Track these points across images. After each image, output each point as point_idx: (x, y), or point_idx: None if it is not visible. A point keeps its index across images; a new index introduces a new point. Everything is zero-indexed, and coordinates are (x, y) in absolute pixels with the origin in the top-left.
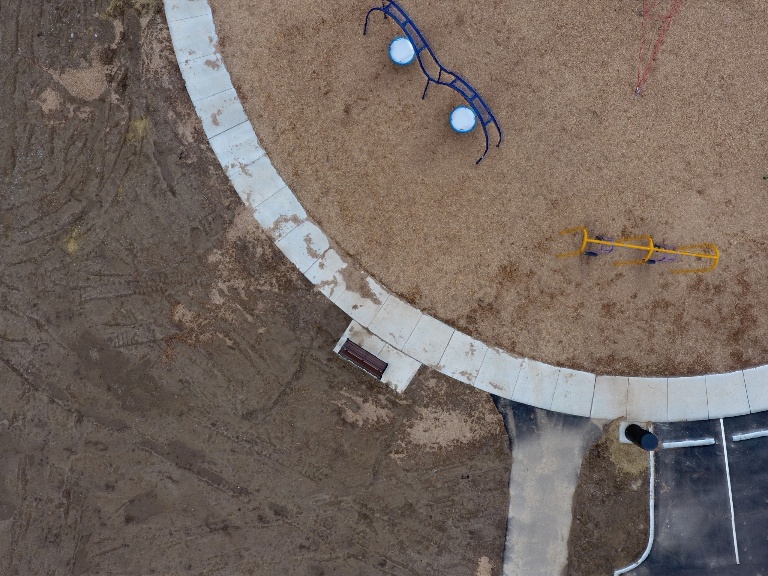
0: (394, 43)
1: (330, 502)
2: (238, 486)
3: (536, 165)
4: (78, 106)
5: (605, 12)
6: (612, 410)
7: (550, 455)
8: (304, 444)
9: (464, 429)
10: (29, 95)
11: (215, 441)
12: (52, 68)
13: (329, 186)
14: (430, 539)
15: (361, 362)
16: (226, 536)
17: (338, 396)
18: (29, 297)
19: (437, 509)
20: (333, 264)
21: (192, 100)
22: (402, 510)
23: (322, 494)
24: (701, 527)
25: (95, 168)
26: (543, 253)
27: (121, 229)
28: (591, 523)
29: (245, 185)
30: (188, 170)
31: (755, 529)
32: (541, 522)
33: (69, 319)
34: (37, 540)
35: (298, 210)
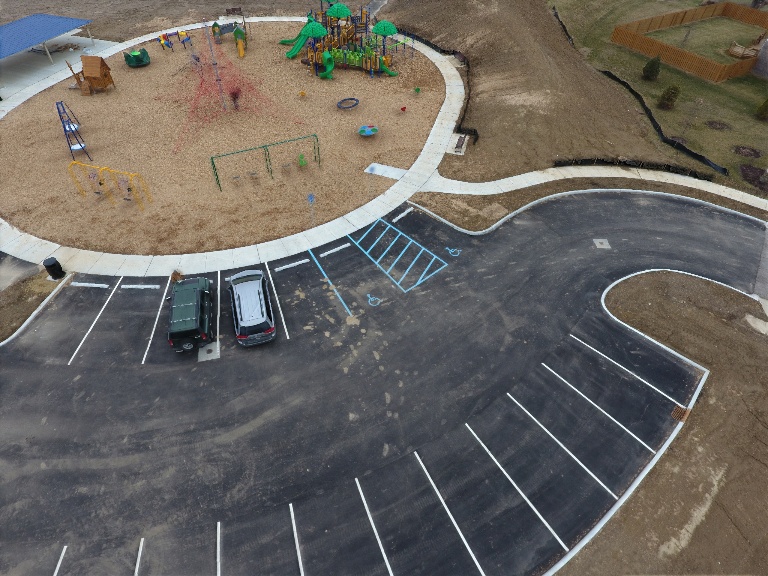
0: None
1: None
2: None
3: None
4: None
5: None
6: None
7: None
8: None
9: None
10: None
11: None
12: None
13: None
14: None
15: None
16: None
17: None
18: None
19: None
20: None
21: None
22: None
23: None
24: (59, 335)
25: None
26: None
27: None
28: None
29: None
30: None
31: (99, 343)
32: None
33: None
34: None
35: None
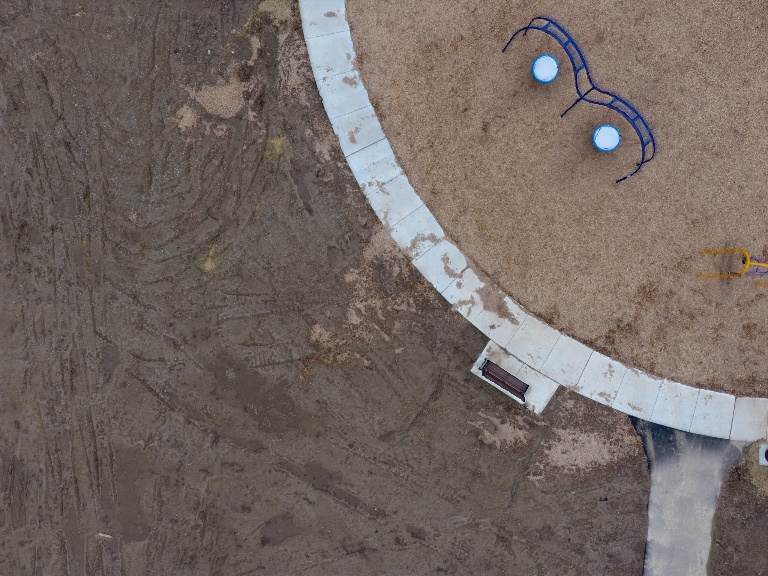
0: (538, 61)
1: (468, 524)
2: (375, 508)
3: (676, 184)
4: (215, 123)
5: (747, 29)
6: (752, 432)
7: (689, 477)
8: (442, 466)
9: (602, 451)
10: (165, 112)
11: (352, 462)
12: (189, 85)
13: (467, 205)
14: (569, 562)
15: (504, 384)
16: (363, 558)
17: (476, 417)
18: (165, 316)
19: (575, 532)
20: (471, 284)
21: (329, 118)
22: (541, 533)
23: (460, 516)
24: None
25: (232, 186)
26: (683, 273)
27: (258, 248)
28: (731, 546)
29: (382, 204)
30: (325, 188)
31: None
32: (680, 545)
33: (206, 339)
34: (173, 562)
35: (436, 229)
